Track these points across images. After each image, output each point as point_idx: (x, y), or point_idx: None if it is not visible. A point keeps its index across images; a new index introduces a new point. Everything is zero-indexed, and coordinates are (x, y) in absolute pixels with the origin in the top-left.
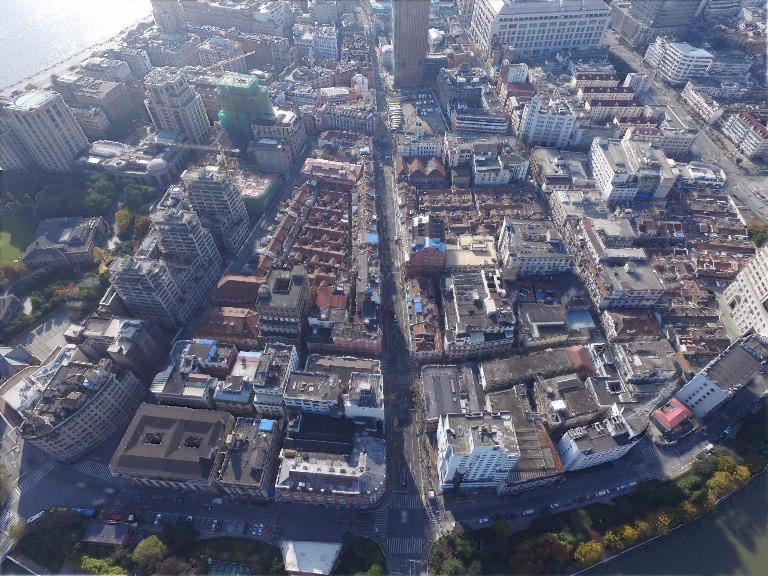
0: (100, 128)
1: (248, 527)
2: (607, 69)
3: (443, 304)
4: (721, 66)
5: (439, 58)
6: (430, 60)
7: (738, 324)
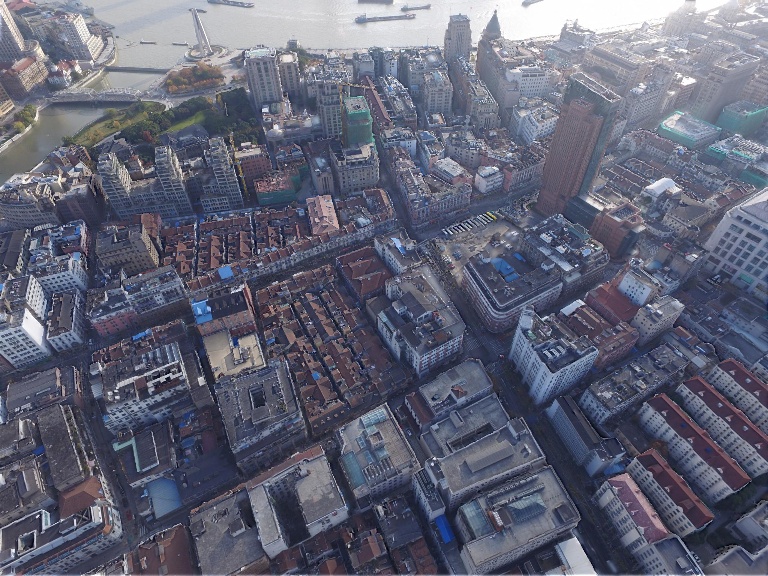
0: (309, 96)
1: None
2: None
3: None
4: None
5: (592, 206)
6: (582, 202)
7: None
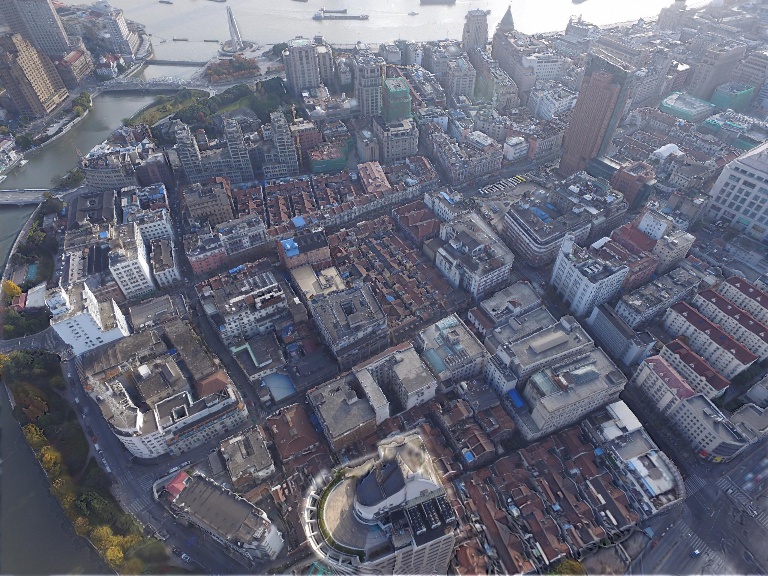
0: (342, 83)
1: None
2: None
3: None
4: None
5: (610, 166)
6: (600, 163)
7: None
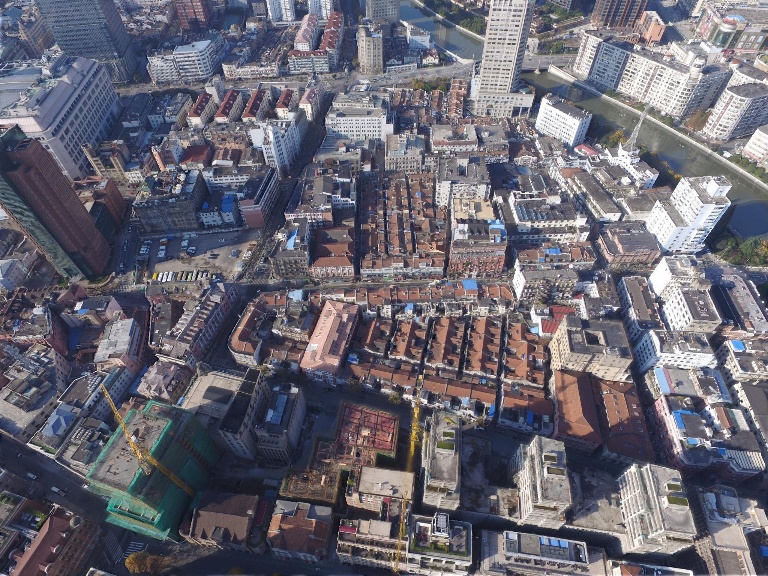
0: None
1: None
2: (182, 98)
3: (540, 238)
4: (214, 46)
5: (91, 209)
6: None
7: (503, 115)
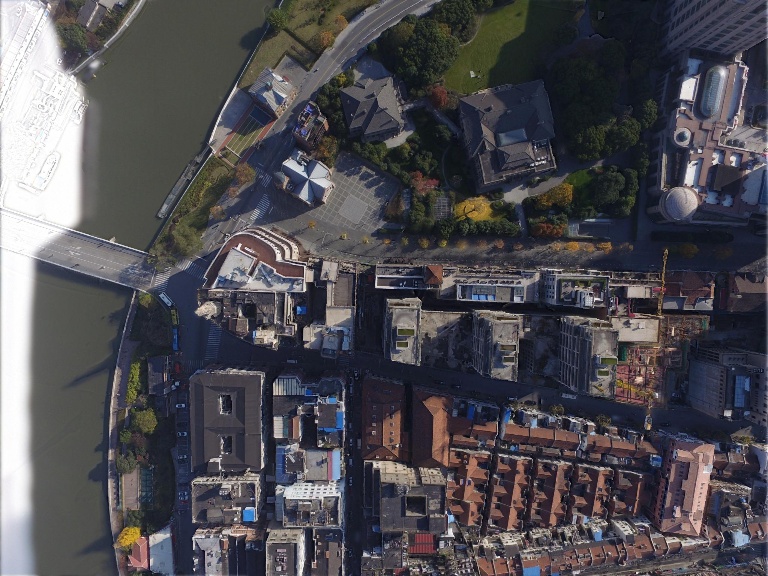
0: None
1: (185, 486)
2: None
3: None
4: None
5: None
6: None
7: None
